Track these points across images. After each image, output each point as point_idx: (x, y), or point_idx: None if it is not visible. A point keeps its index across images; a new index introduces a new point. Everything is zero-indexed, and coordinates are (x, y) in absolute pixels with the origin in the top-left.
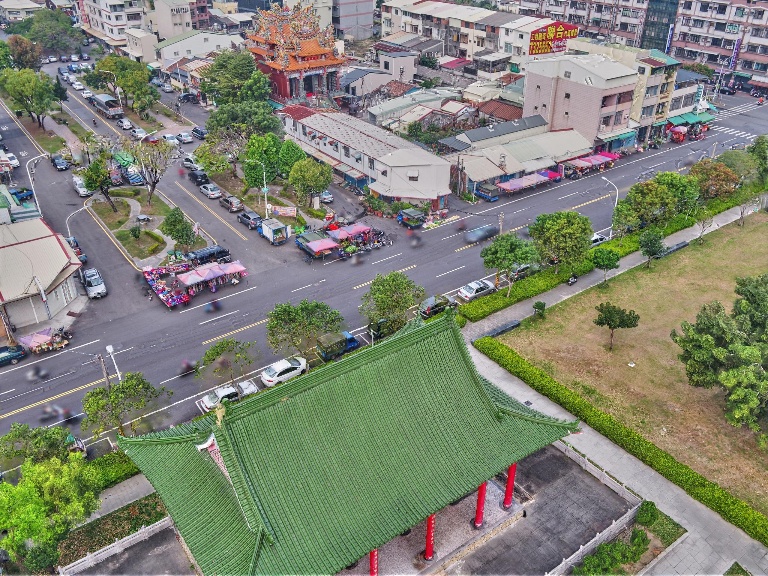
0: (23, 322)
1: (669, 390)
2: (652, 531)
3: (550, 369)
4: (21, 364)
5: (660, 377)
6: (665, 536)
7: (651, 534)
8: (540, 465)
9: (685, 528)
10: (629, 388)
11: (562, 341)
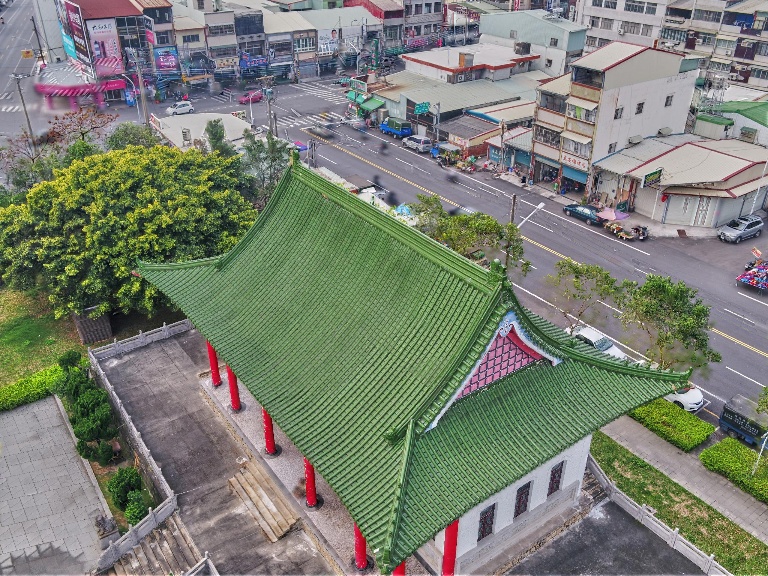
0: (643, 210)
1: None
2: None
3: None
4: (589, 227)
5: None
6: None
7: None
8: None
9: None
10: None
11: None
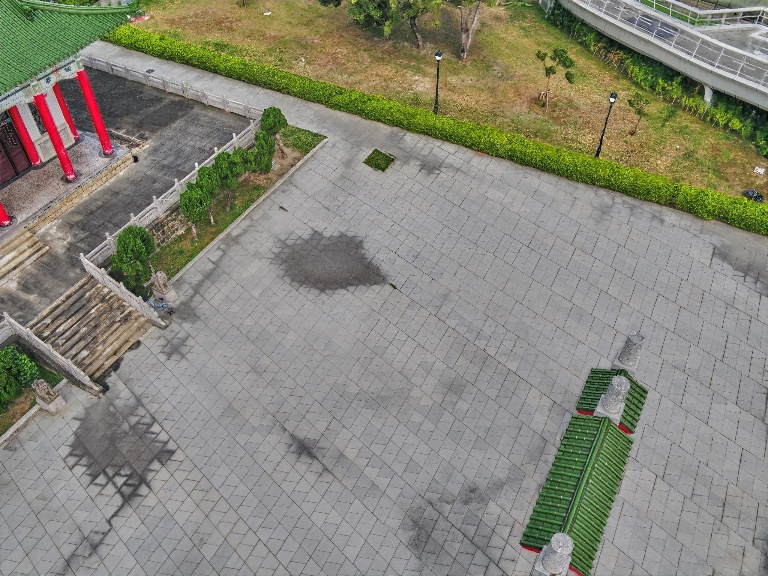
0: None
1: (307, 26)
2: (290, 146)
3: (176, 36)
4: None
5: (298, 17)
6: (304, 146)
7: (289, 149)
8: (155, 113)
9: (325, 135)
10: (265, 34)
11: (189, 8)
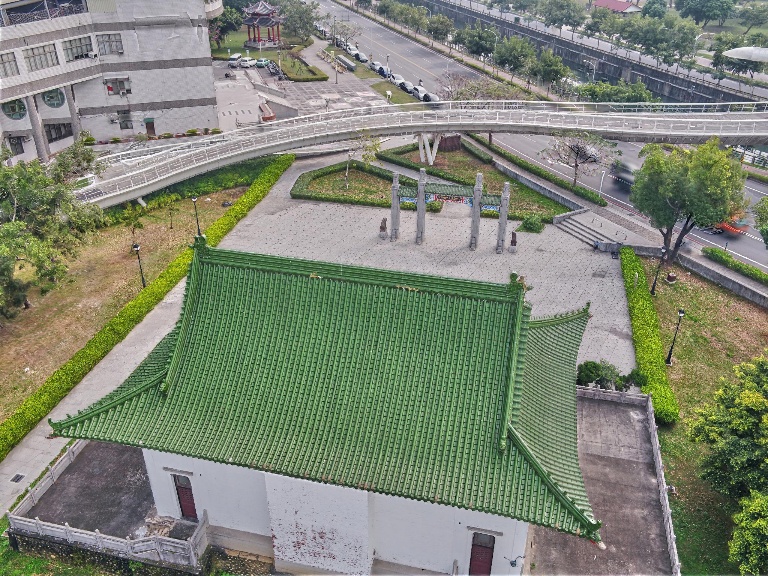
0: None
1: None
2: None
3: None
4: None
5: None
6: None
7: None
8: None
9: None
10: None
11: None
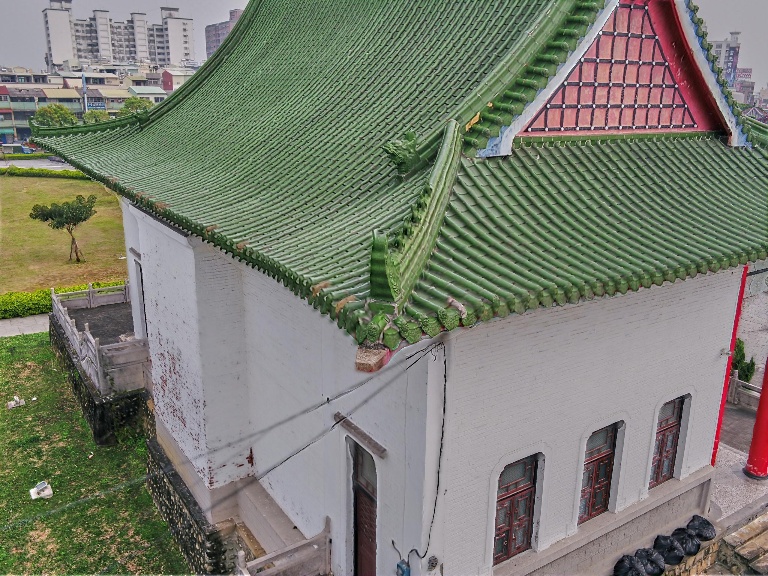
0: None
1: None
2: None
3: None
4: None
5: None
6: None
7: None
8: None
9: None
10: None
11: (21, 280)
